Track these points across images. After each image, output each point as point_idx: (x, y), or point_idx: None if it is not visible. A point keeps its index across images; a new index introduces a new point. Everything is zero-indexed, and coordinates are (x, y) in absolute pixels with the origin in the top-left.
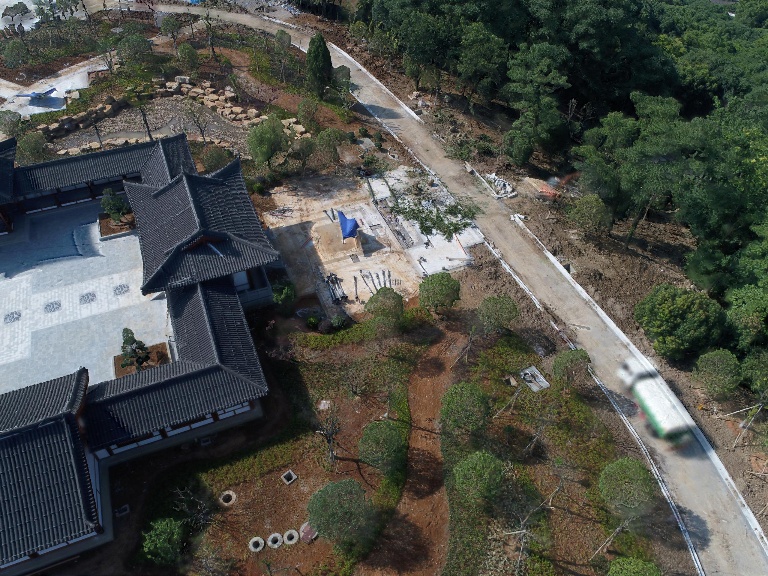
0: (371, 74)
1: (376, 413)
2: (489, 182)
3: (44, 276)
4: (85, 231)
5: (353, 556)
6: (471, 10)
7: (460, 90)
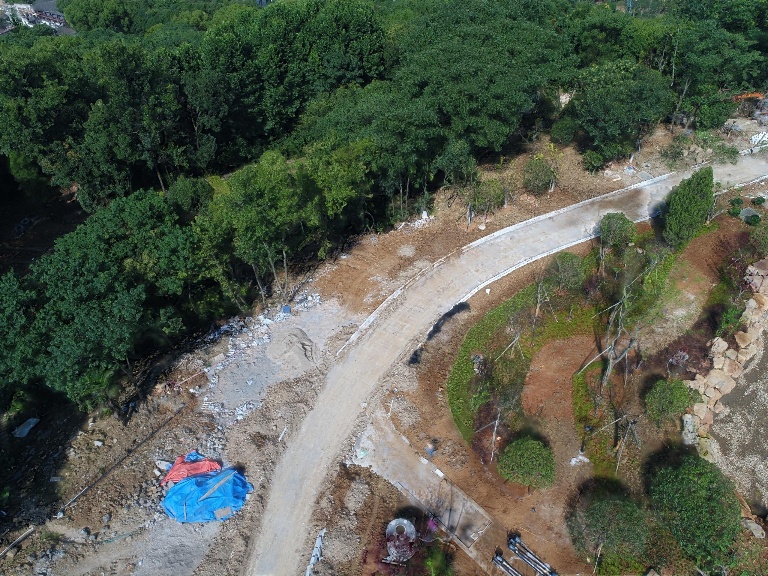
0: (567, 207)
1: None
2: (763, 144)
3: None
4: None
5: None
6: (578, 60)
7: (548, 154)
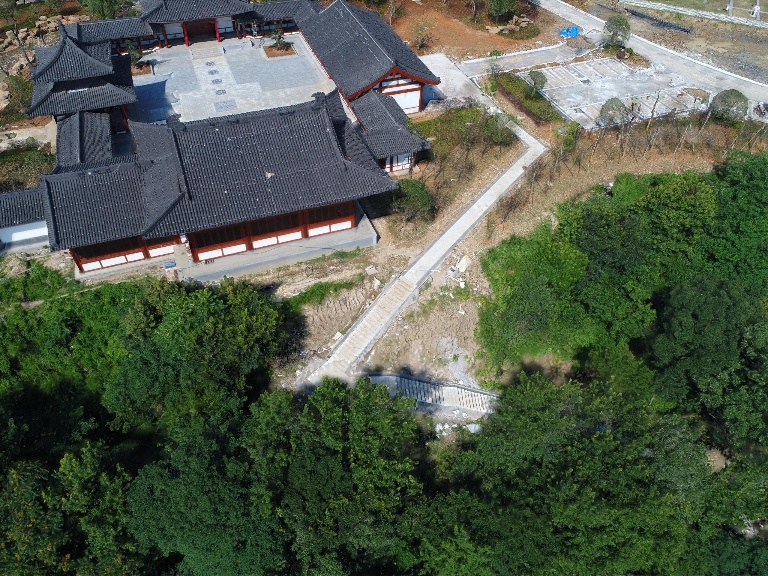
0: None
1: (322, 1)
2: None
3: (184, 89)
4: (138, 82)
5: (384, 3)
6: None
7: None
